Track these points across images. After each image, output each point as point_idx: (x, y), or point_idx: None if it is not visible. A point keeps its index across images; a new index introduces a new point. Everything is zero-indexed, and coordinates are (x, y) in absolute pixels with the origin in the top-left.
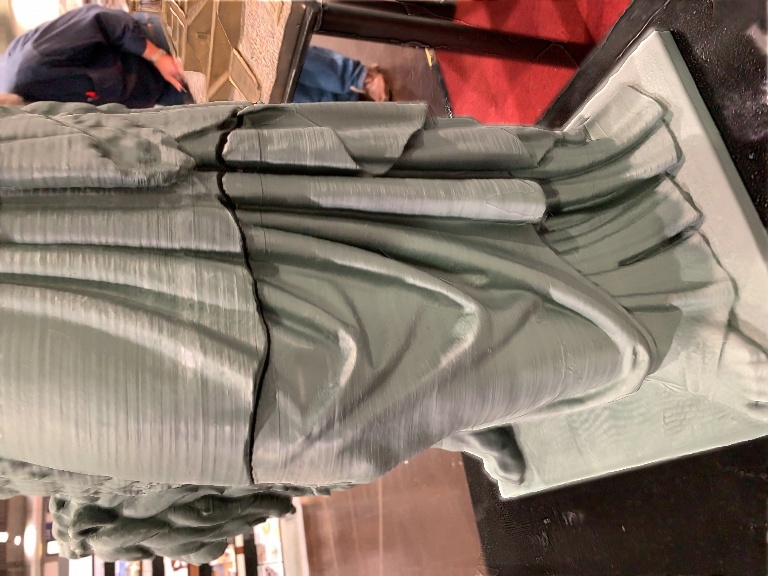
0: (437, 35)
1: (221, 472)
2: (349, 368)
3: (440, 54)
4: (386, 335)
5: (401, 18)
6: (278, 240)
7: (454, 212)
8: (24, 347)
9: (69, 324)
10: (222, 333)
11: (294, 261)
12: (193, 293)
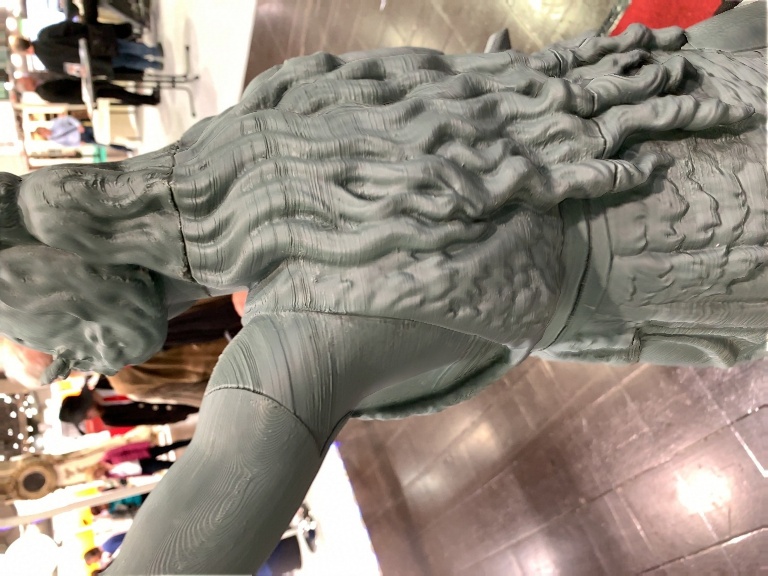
0: None
1: None
2: (760, 355)
3: None
4: None
5: None
6: None
7: None
8: None
9: None
10: None
11: None
12: None
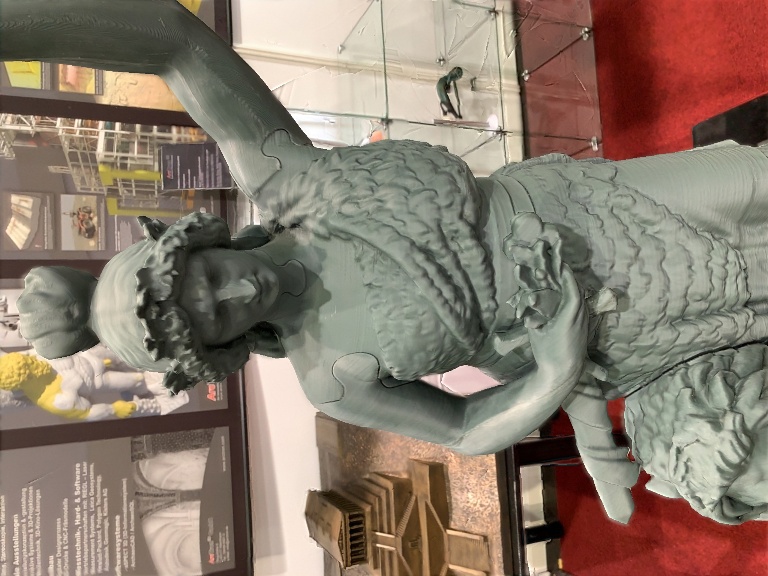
0: None
1: (761, 163)
2: None
3: (572, 568)
4: None
5: (557, 439)
6: None
7: None
8: None
9: None
10: None
11: None
12: None
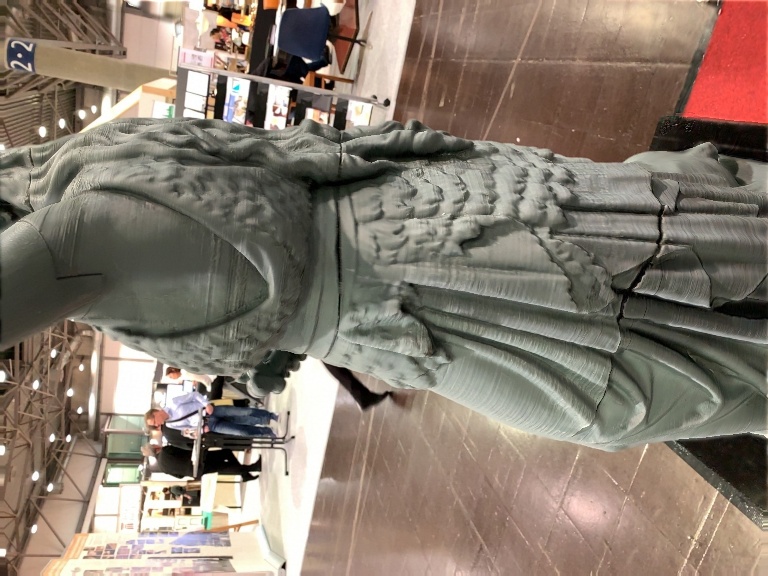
0: None
1: None
2: (636, 423)
3: None
4: (662, 404)
5: None
6: (635, 344)
7: (747, 340)
8: (488, 380)
9: (512, 372)
10: (582, 391)
11: (636, 352)
12: (579, 370)
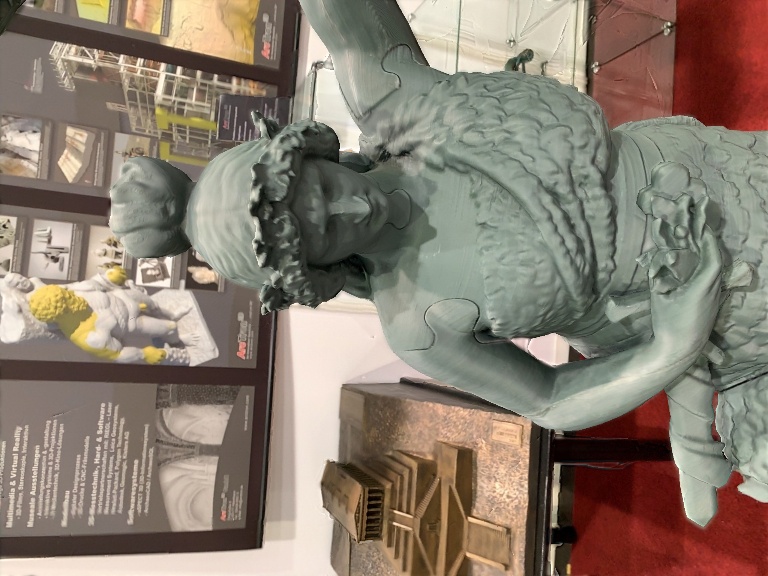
0: (621, 450)
1: None
2: None
3: (581, 575)
4: None
5: (592, 440)
6: None
7: None
8: None
9: None
10: None
11: None
12: None
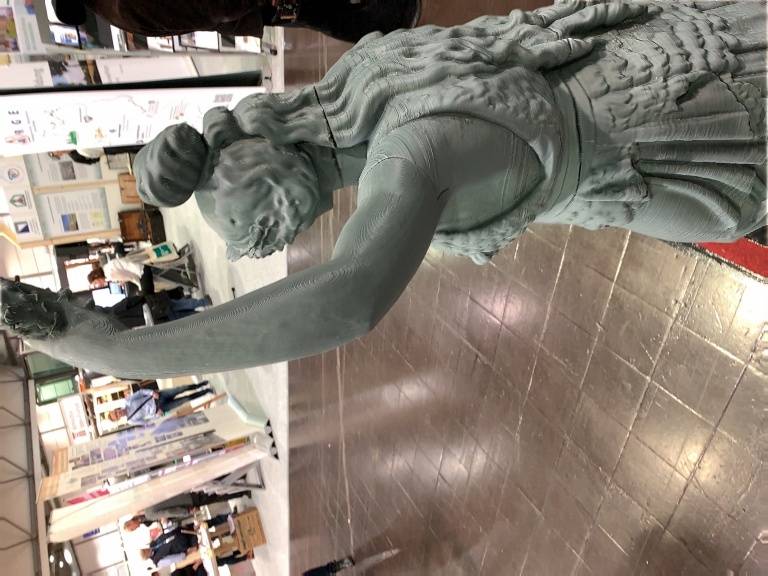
0: None
1: None
2: (763, 215)
3: None
4: None
5: None
6: None
7: None
8: (673, 207)
9: (689, 197)
10: (732, 200)
11: None
12: (734, 184)
